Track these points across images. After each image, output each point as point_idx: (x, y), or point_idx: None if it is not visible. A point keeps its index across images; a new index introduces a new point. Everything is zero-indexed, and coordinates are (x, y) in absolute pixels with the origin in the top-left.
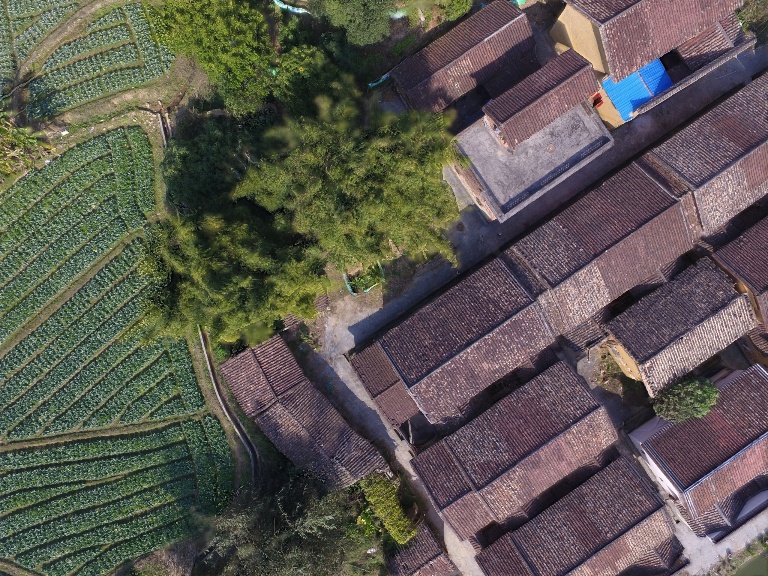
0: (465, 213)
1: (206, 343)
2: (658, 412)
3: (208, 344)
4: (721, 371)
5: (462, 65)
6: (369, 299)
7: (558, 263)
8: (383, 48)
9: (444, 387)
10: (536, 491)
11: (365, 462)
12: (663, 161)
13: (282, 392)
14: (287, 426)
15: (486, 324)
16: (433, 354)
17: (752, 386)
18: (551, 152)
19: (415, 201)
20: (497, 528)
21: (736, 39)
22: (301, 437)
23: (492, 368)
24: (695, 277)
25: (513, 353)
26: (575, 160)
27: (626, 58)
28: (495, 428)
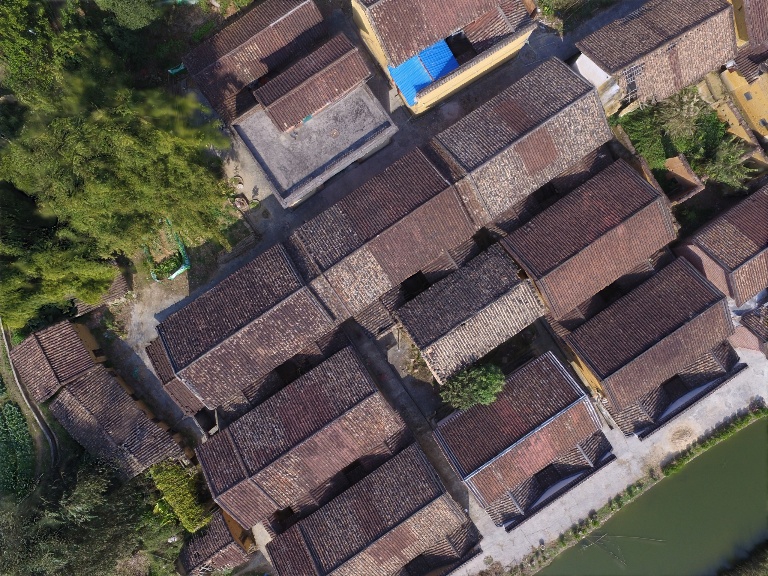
0: (270, 200)
1: (7, 330)
2: (445, 399)
3: (8, 331)
4: (530, 359)
5: (250, 51)
6: (175, 286)
7: (332, 248)
8: (184, 35)
9: (218, 373)
10: (319, 478)
11: (157, 450)
12: (443, 146)
13: (67, 378)
14: (77, 413)
15: (257, 309)
16: (204, 339)
17: (542, 373)
18: (335, 137)
19: (152, 182)
20: (295, 517)
21: (519, 24)
22: (90, 424)
23: (269, 354)
24: (484, 263)
25: (290, 339)
26: (359, 145)
27: (401, 42)
28: (276, 415)
